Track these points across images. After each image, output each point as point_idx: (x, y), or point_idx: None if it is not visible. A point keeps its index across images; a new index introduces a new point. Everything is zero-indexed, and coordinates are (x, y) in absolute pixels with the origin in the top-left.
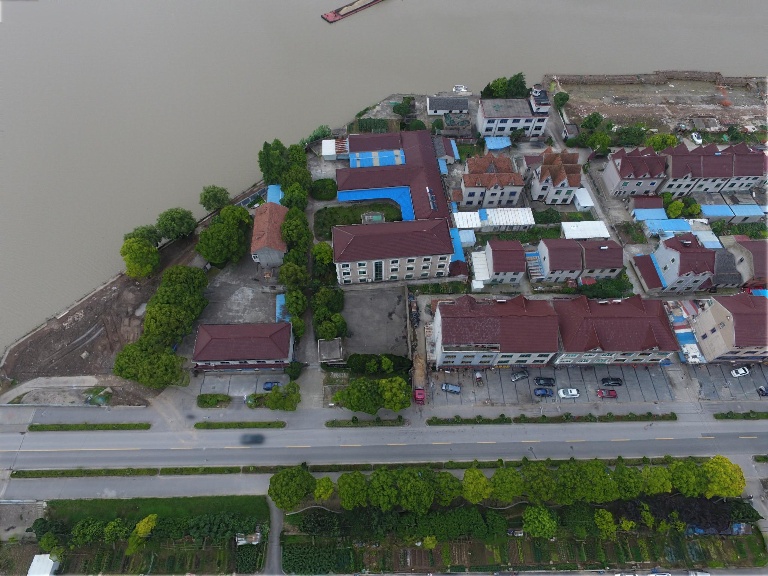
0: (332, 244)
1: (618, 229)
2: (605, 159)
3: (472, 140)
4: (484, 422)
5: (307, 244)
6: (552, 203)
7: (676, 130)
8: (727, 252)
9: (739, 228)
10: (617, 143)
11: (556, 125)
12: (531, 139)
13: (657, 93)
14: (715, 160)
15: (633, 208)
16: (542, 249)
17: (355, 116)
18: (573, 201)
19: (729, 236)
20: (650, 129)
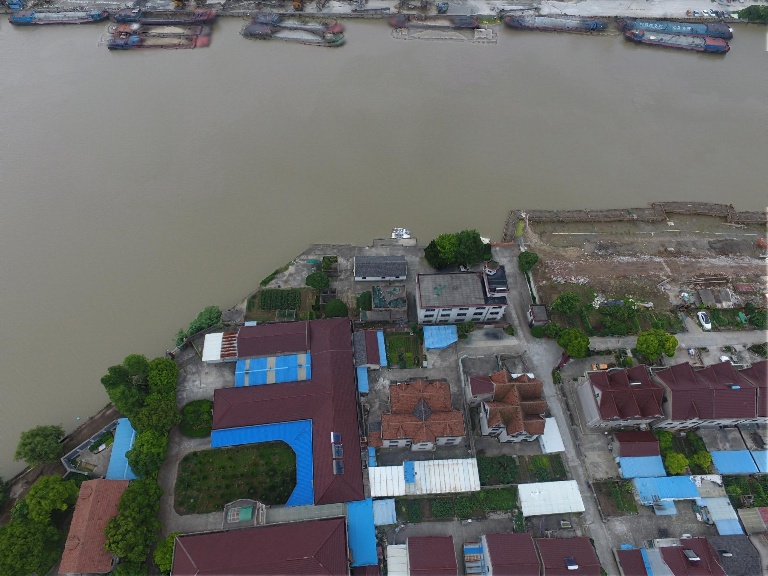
0: (170, 574)
1: (597, 489)
2: (583, 359)
3: (407, 329)
4: None
5: (149, 544)
6: (508, 441)
7: (677, 307)
8: (750, 547)
9: (764, 485)
10: (599, 333)
11: (521, 296)
12: (485, 326)
13: (653, 236)
14: (732, 395)
15: (618, 455)
16: (485, 552)
17: (261, 281)
18: (537, 437)
19: (752, 509)
20: (643, 303)
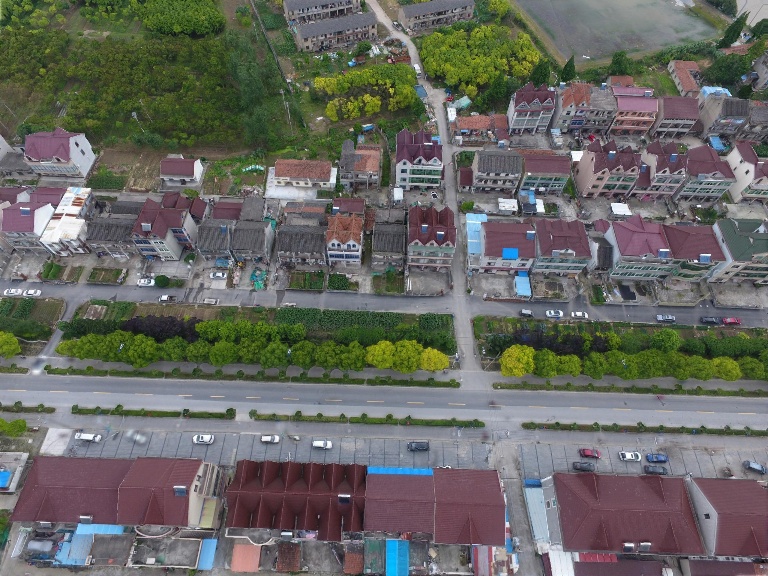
0: None
1: None
2: None
3: None
4: (714, 430)
5: None
6: None
7: None
8: None
9: None
10: None
11: None
12: None
13: None
14: None
15: None
16: None
17: None
18: None
19: None
20: None
